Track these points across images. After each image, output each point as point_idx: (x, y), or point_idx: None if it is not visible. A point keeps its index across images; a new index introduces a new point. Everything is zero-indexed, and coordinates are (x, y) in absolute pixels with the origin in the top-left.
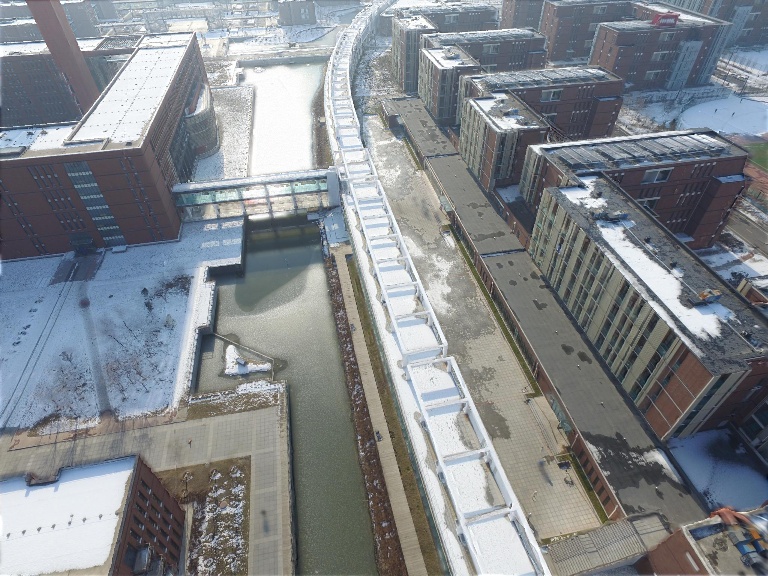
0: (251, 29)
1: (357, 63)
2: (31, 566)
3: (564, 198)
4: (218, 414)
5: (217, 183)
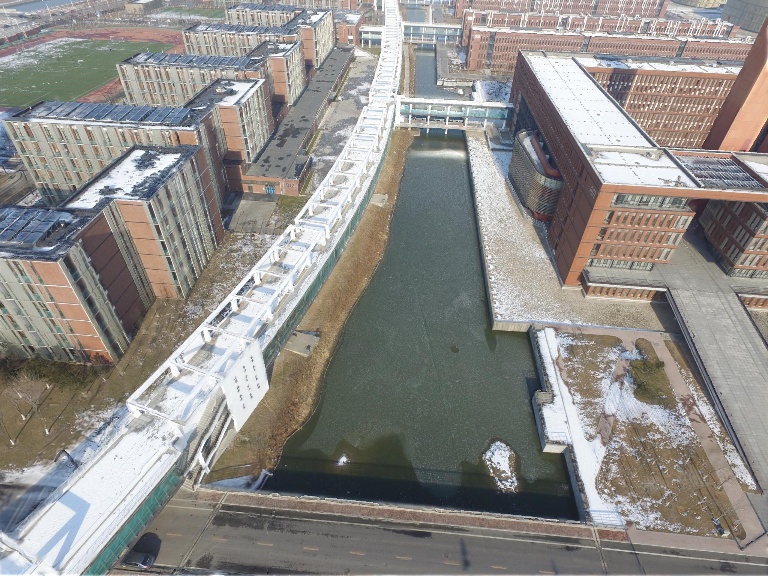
0: None
1: None
2: (487, 28)
3: (314, 25)
4: (462, 78)
5: (483, 104)
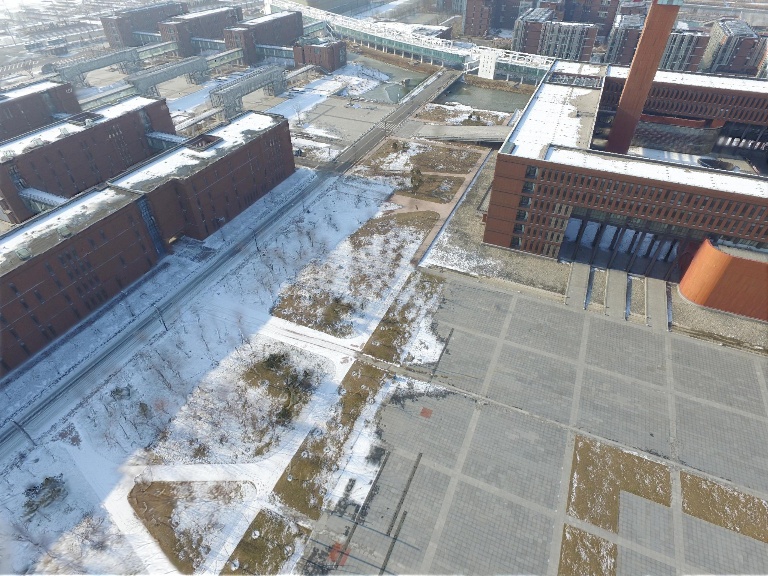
0: (316, 83)
1: (500, 74)
2: None
3: None
4: None
5: None
